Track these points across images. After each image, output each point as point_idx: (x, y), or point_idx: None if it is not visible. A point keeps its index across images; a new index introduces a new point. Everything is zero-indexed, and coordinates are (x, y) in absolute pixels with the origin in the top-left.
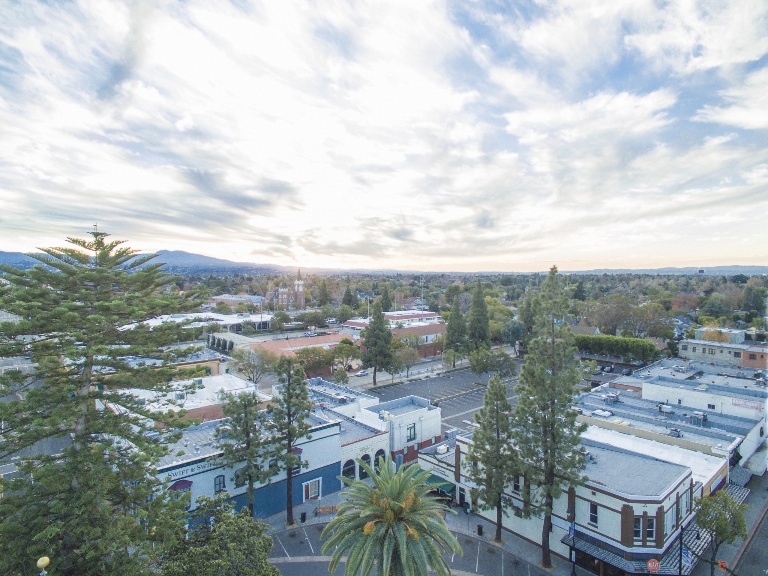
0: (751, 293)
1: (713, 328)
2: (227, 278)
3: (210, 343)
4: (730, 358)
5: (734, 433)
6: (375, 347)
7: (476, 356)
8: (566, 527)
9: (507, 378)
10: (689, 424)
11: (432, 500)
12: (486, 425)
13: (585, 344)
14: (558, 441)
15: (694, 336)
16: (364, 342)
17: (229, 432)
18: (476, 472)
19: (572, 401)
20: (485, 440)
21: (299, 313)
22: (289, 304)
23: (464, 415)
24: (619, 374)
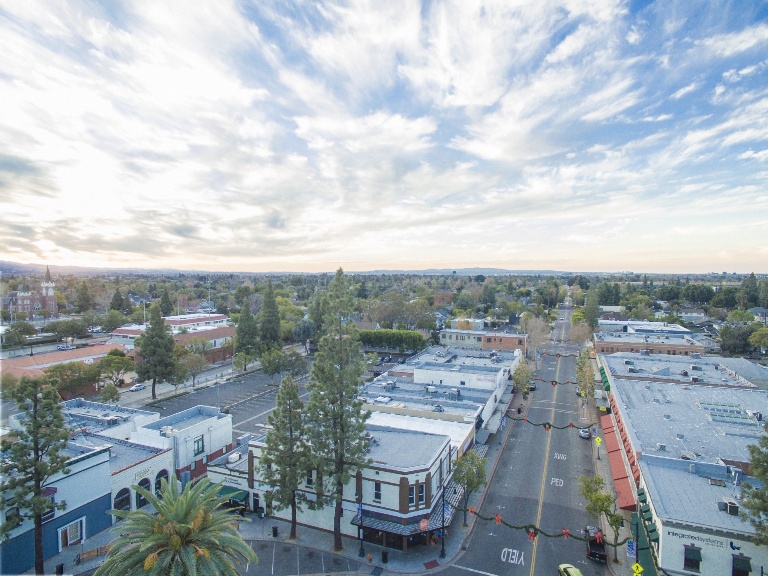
0: (487, 290)
1: (463, 319)
2: None
3: None
4: (475, 342)
5: (478, 403)
6: (153, 356)
7: (268, 357)
8: (355, 509)
9: (299, 376)
10: (448, 400)
11: (224, 513)
12: (279, 426)
13: (368, 338)
14: (346, 431)
15: (450, 326)
16: (139, 352)
17: None
18: (270, 474)
19: (358, 392)
20: (278, 441)
21: (49, 322)
22: (33, 312)
23: (257, 419)
24: (396, 363)
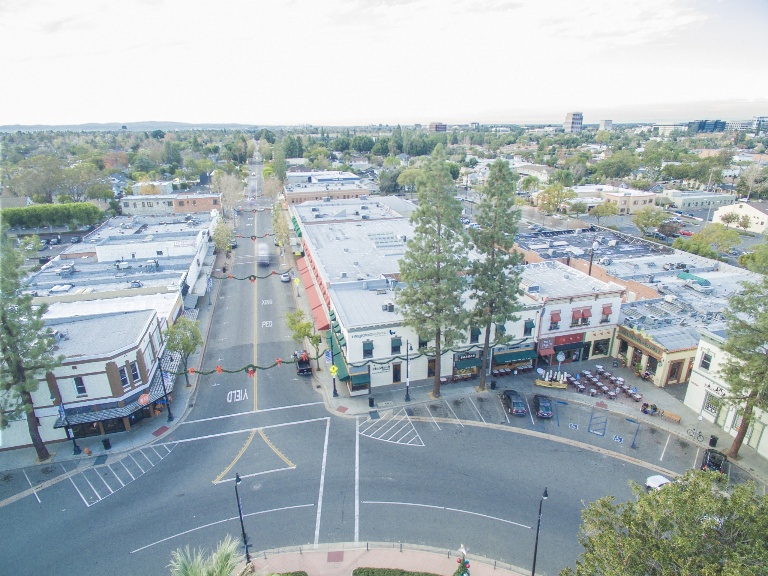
0: (170, 147)
1: (146, 182)
2: None
3: None
4: (165, 208)
5: (181, 270)
6: None
7: None
8: (55, 413)
9: None
10: (146, 273)
11: None
12: None
13: (18, 219)
14: (16, 333)
15: (132, 192)
16: None
17: None
18: None
19: (21, 286)
20: None
21: None
22: None
23: None
24: (68, 244)
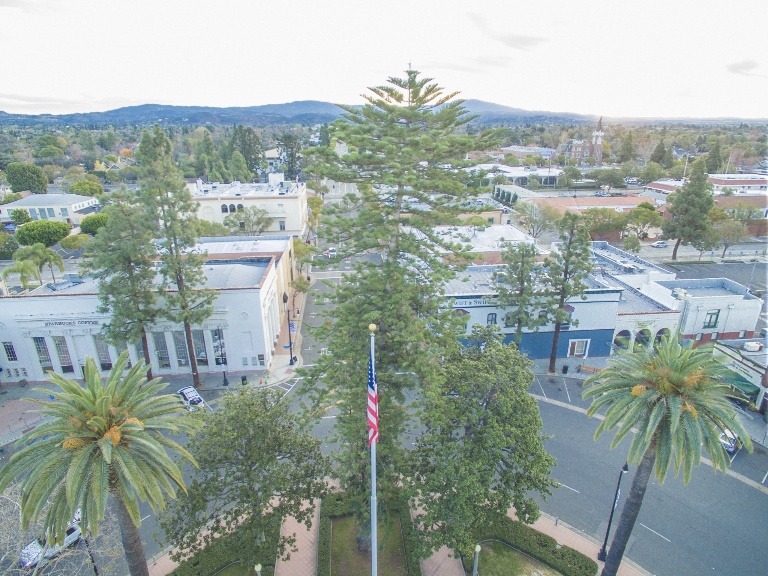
0: None
1: None
2: (518, 128)
3: (495, 194)
4: None
5: None
6: (684, 215)
7: None
8: None
9: None
10: None
11: (721, 395)
12: None
13: None
14: None
15: None
16: (670, 208)
17: (505, 278)
18: None
19: None
20: None
21: (593, 169)
22: (582, 159)
23: None
24: None
